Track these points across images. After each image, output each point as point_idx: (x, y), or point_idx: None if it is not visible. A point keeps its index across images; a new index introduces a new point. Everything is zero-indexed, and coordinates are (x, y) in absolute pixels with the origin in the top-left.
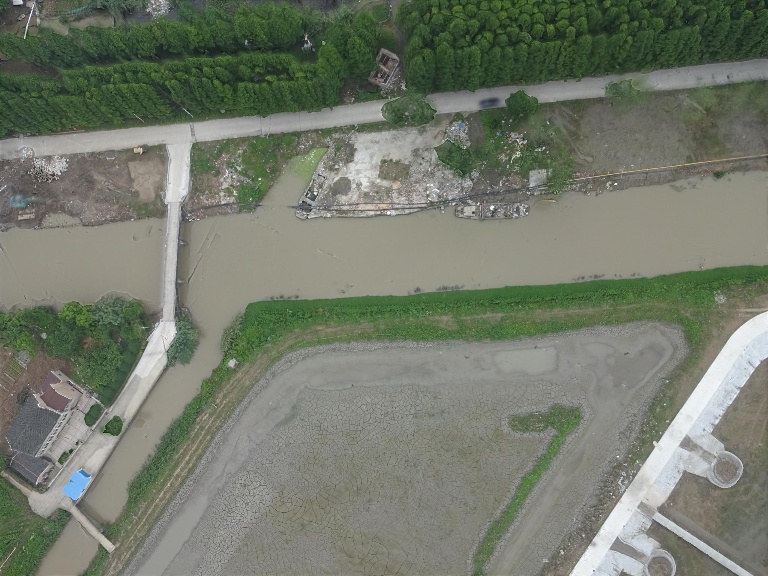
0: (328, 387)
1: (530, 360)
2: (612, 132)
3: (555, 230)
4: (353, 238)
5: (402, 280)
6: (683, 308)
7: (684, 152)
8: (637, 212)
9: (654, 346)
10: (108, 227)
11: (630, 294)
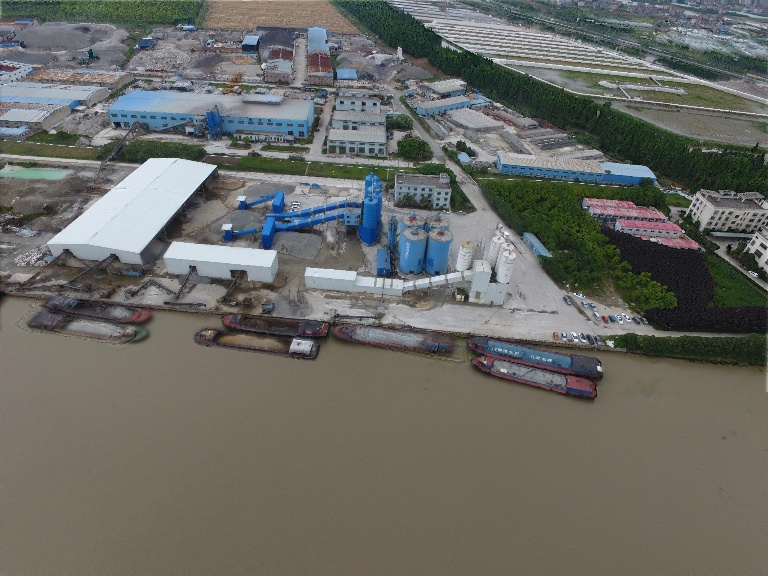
0: (679, 131)
1: None
2: None
3: None
4: None
5: None
6: None
7: None
8: None
9: None
10: None
11: None
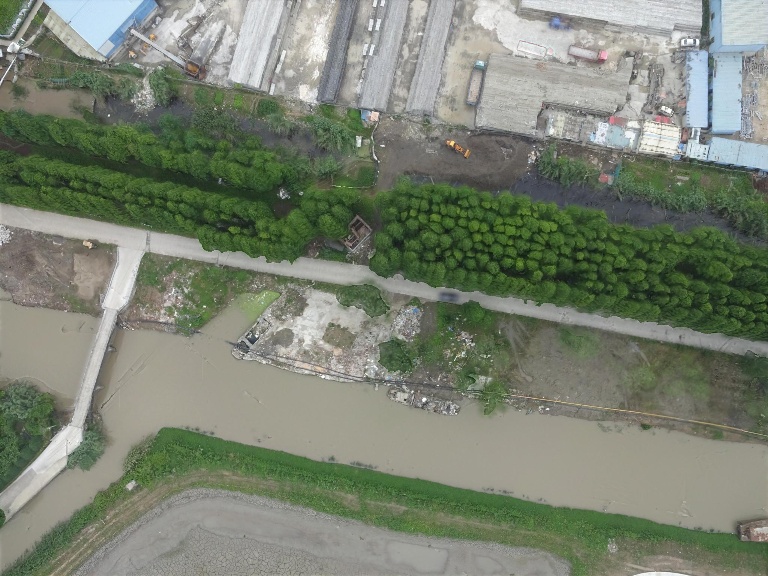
0: (220, 532)
1: (421, 556)
2: (557, 360)
3: (479, 435)
4: (283, 389)
5: (320, 442)
6: (576, 547)
7: (619, 398)
8: (561, 439)
9: (540, 574)
10: (39, 311)
11: (531, 520)
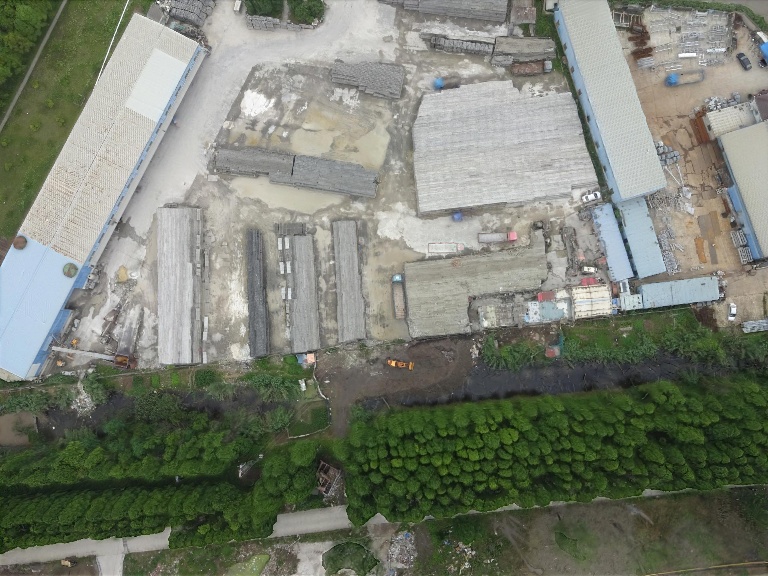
0: None
1: None
2: None
3: None
4: None
5: None
6: None
7: (633, 565)
8: None
9: None
10: None
11: None
